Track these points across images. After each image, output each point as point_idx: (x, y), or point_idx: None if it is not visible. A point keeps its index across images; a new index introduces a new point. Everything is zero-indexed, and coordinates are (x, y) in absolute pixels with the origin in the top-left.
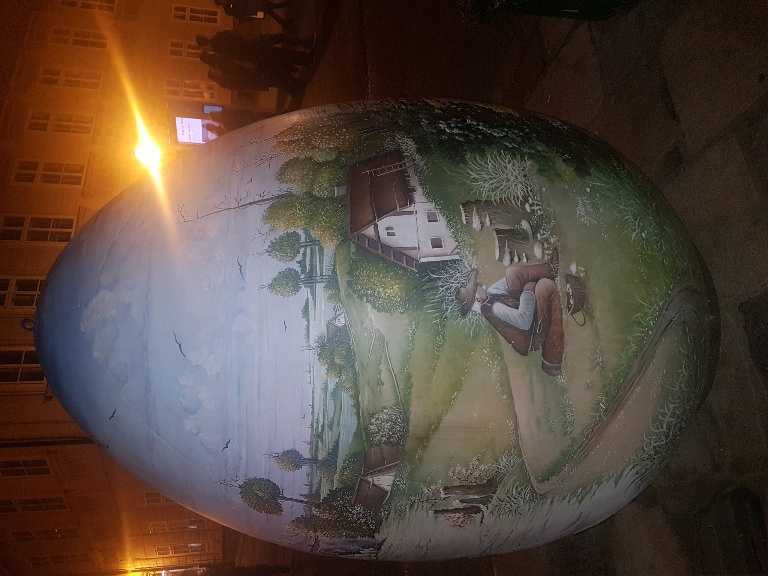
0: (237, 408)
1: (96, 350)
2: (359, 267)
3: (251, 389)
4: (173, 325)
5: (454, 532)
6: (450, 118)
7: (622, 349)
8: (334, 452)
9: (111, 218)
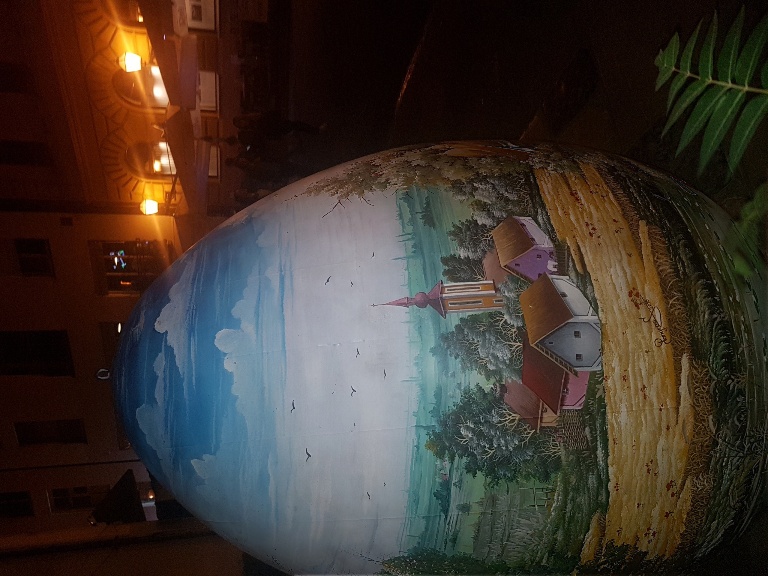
0: None
1: None
2: None
3: None
4: None
5: None
6: None
7: None
8: None
9: (198, 500)
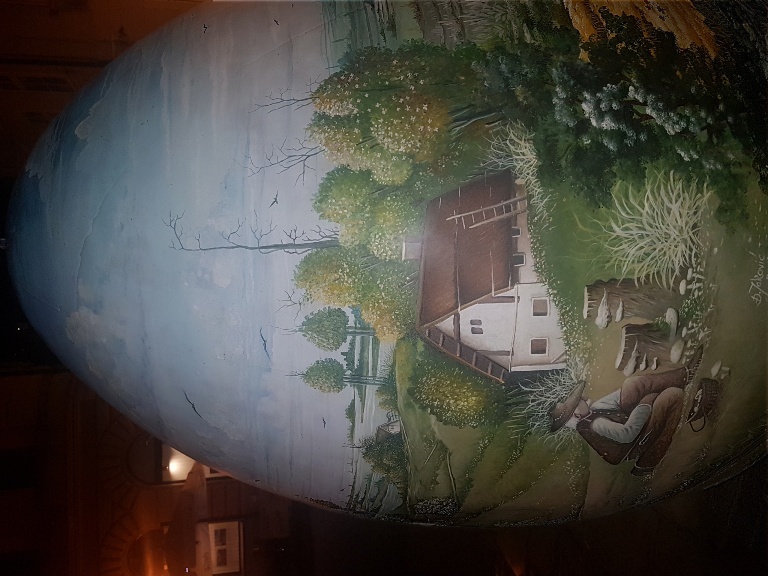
0: (266, 468)
1: (92, 366)
2: (426, 373)
3: (282, 459)
4: (182, 383)
5: None
6: (602, 83)
7: (735, 442)
8: (374, 511)
9: (76, 186)
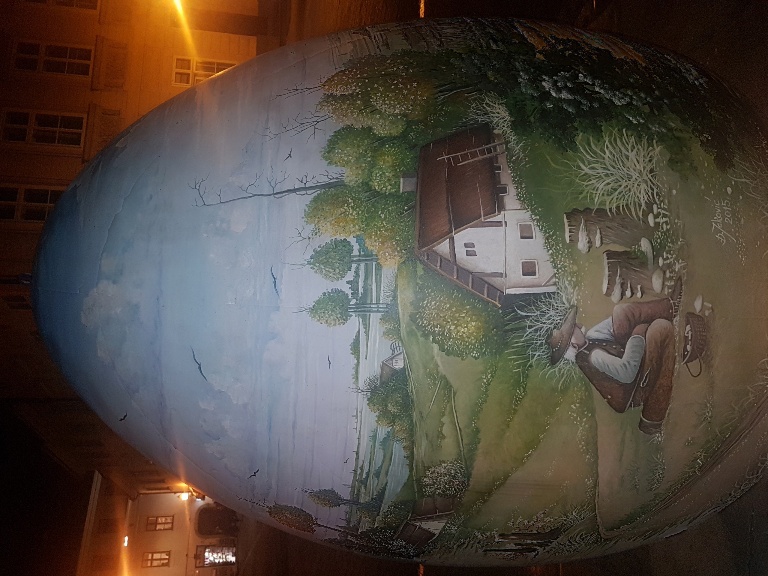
0: (267, 442)
1: (101, 349)
2: (427, 296)
3: (284, 425)
4: (191, 340)
5: (502, 561)
6: (556, 71)
7: (737, 401)
8: (379, 498)
9: (112, 178)
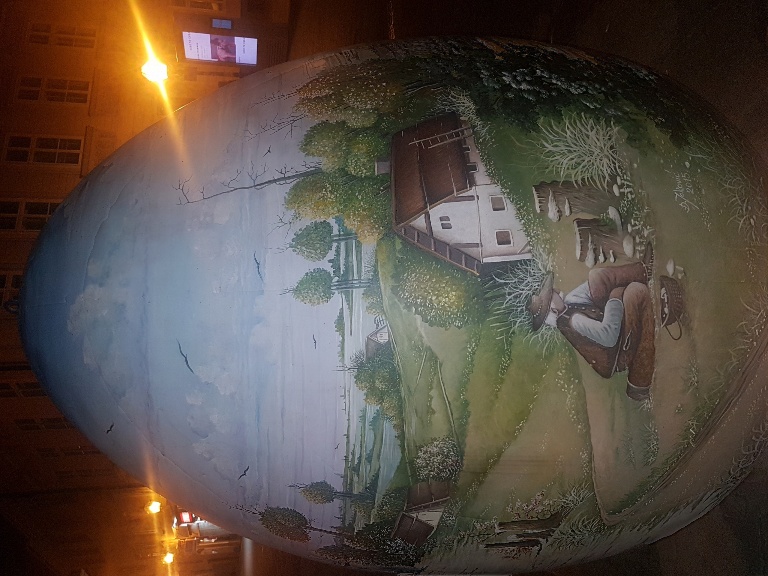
0: (256, 434)
1: (87, 355)
2: (406, 269)
3: (273, 413)
4: (177, 333)
5: (505, 562)
6: (515, 68)
7: (721, 365)
8: (372, 486)
9: (99, 191)
